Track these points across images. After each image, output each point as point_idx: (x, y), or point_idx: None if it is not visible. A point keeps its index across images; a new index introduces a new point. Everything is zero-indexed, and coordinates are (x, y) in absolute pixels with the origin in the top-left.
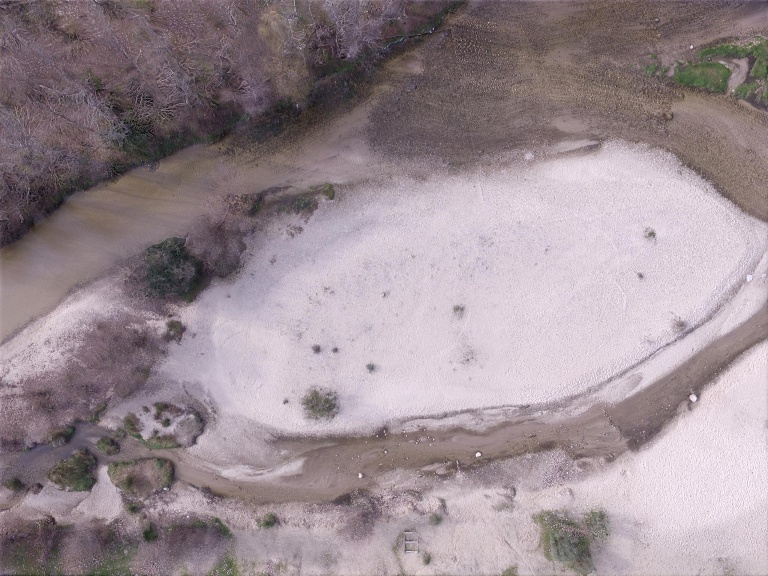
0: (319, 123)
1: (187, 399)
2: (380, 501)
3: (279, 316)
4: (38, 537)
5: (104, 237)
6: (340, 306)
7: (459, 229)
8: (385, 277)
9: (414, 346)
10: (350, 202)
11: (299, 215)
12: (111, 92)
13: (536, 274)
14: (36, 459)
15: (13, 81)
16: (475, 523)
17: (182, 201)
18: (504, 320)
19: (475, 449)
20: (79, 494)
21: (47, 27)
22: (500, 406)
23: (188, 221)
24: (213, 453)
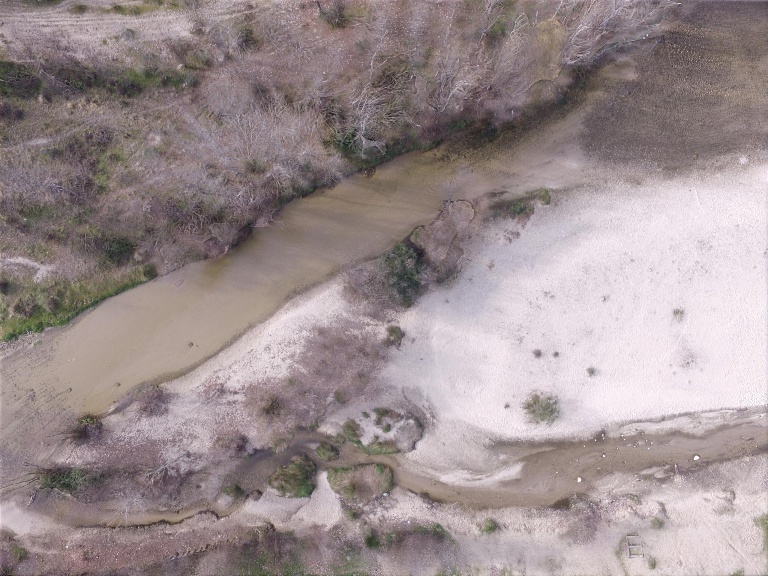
0: (533, 129)
1: (406, 404)
2: (598, 505)
3: (499, 321)
4: (259, 544)
5: (321, 243)
6: (560, 310)
7: (677, 233)
8: (605, 281)
9: (634, 350)
10: (566, 207)
11: (515, 220)
12: (333, 100)
13: (755, 277)
14: (255, 465)
15: (235, 89)
16: (697, 527)
17: (399, 207)
18: (724, 323)
19: (693, 452)
20: (299, 500)
21: (270, 36)
22: (718, 409)
23: (405, 227)
24: (432, 458)
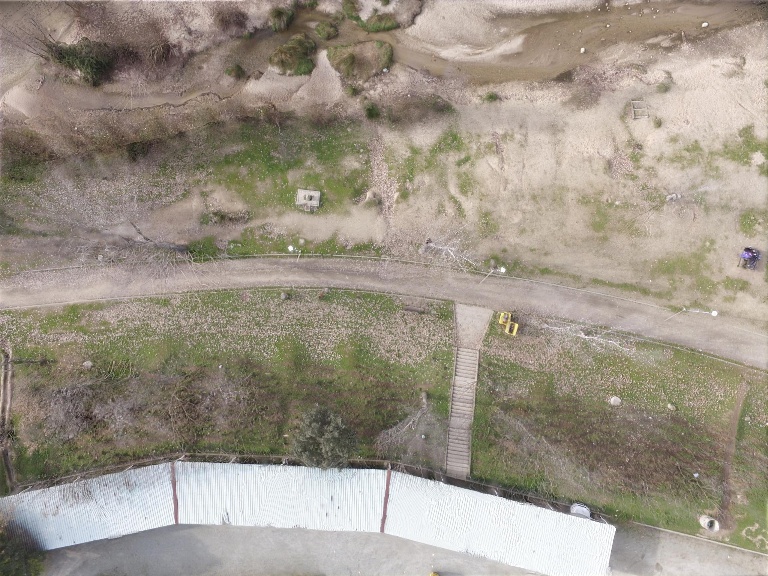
0: None
1: None
2: (602, 77)
3: None
4: (261, 120)
5: None
6: None
7: None
8: None
9: None
10: None
11: None
12: None
13: None
14: (256, 45)
15: None
16: (705, 90)
17: None
18: None
19: (701, 19)
20: (299, 78)
21: None
22: None
23: None
24: (432, 33)
